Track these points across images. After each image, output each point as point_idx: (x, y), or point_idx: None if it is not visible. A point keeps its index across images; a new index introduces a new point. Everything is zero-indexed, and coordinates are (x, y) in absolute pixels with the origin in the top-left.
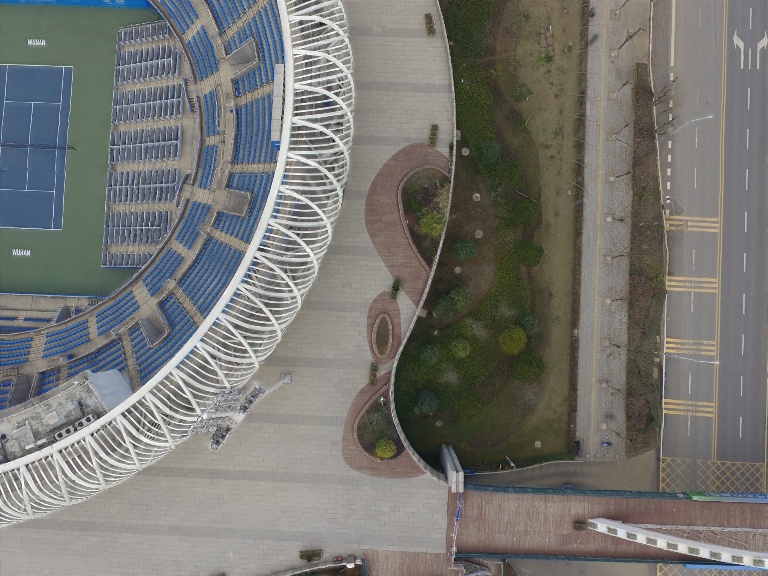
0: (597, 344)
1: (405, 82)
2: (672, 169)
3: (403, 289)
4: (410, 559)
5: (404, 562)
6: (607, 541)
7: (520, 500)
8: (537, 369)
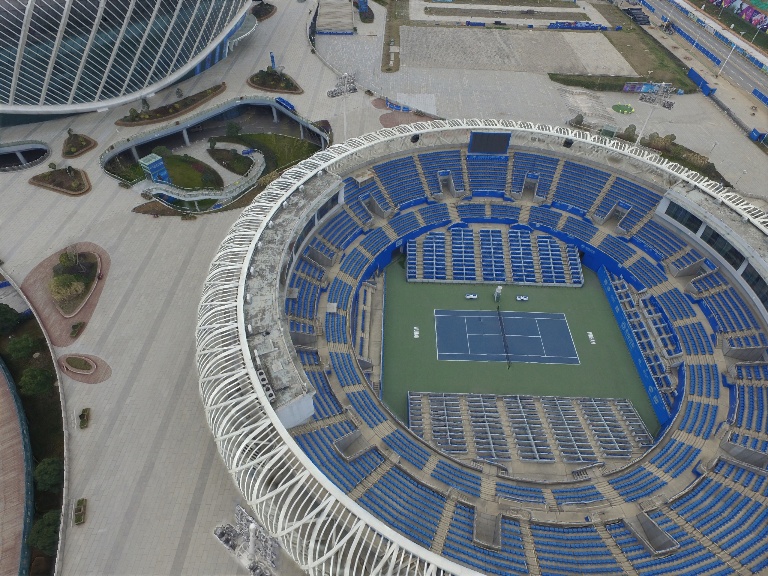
0: None
1: None
2: None
3: None
4: None
5: None
6: None
7: None
8: None
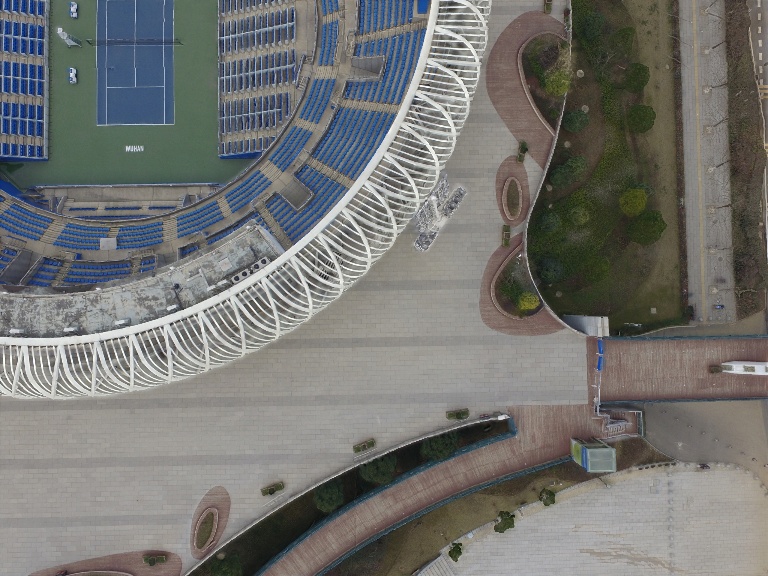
0: (703, 212)
1: None
2: (763, 40)
3: (529, 153)
4: (554, 412)
5: (548, 415)
6: (741, 383)
7: (656, 348)
8: (662, 223)
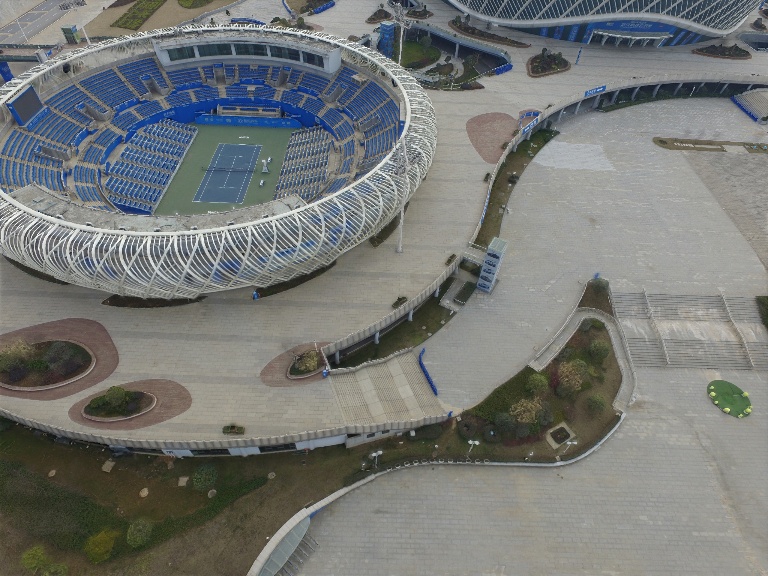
0: None
1: None
2: None
3: None
4: None
5: None
6: None
7: None
8: None
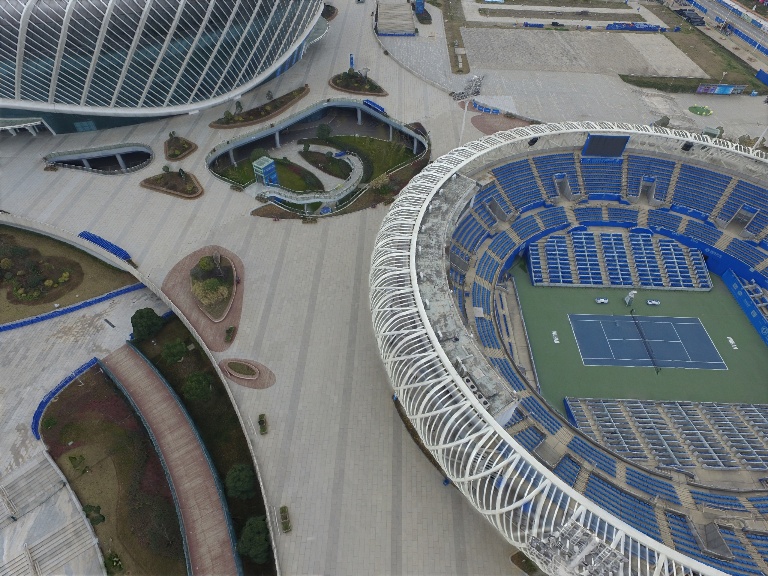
0: None
1: None
2: None
3: None
4: None
5: None
6: None
7: None
8: None
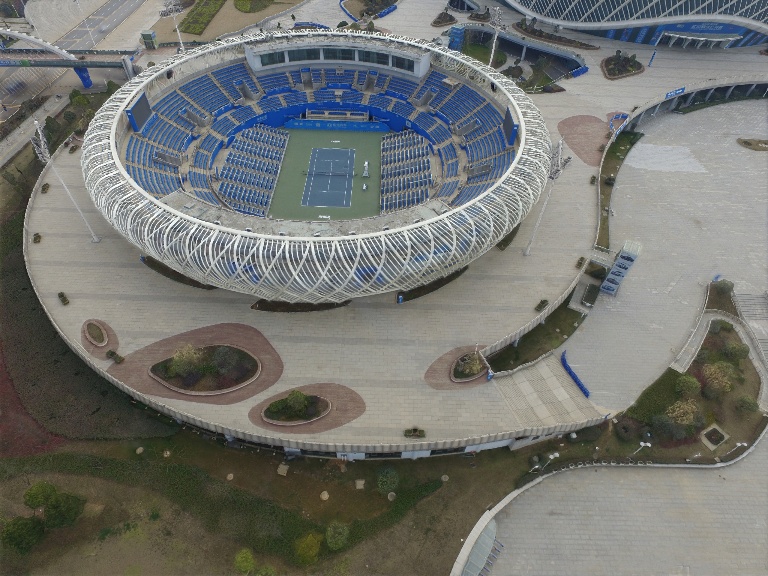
0: (40, 121)
1: (78, 169)
2: None
3: None
4: None
5: None
6: None
7: None
8: None
